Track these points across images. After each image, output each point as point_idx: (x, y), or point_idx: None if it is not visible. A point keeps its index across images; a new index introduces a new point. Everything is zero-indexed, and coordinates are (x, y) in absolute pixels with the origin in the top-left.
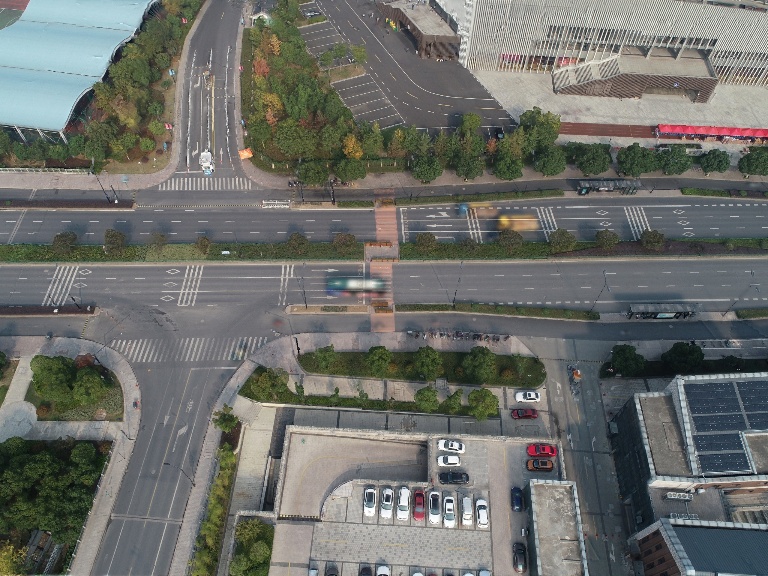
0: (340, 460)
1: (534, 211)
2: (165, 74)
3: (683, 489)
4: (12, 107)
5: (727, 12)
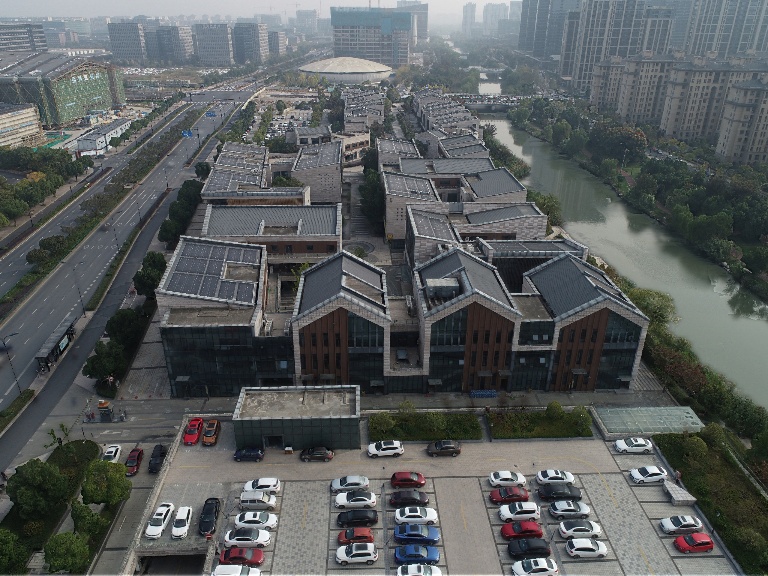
0: None
1: None
2: None
3: (261, 327)
4: None
5: None
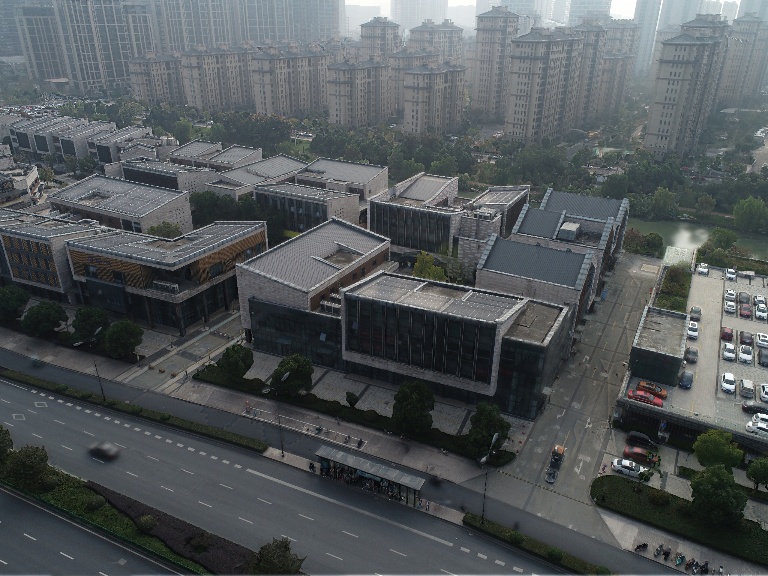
0: None
1: None
2: None
3: None
4: None
5: None
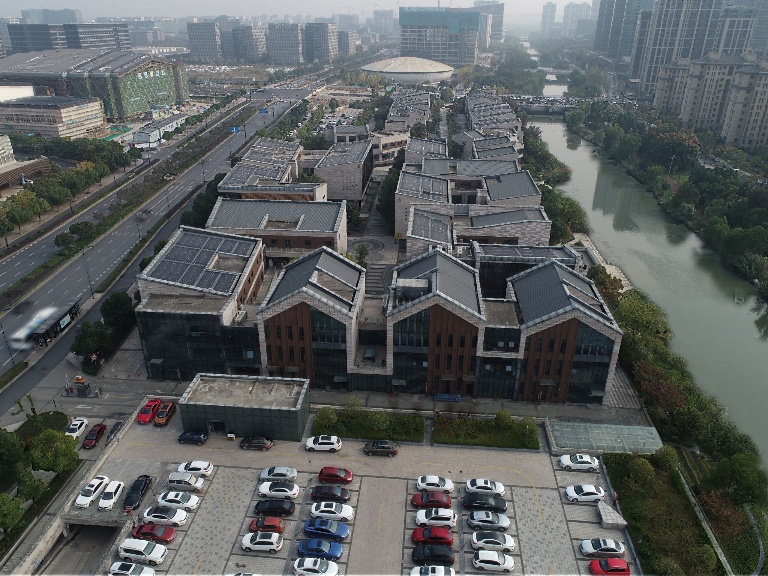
0: None
1: None
2: None
3: None
4: None
5: None
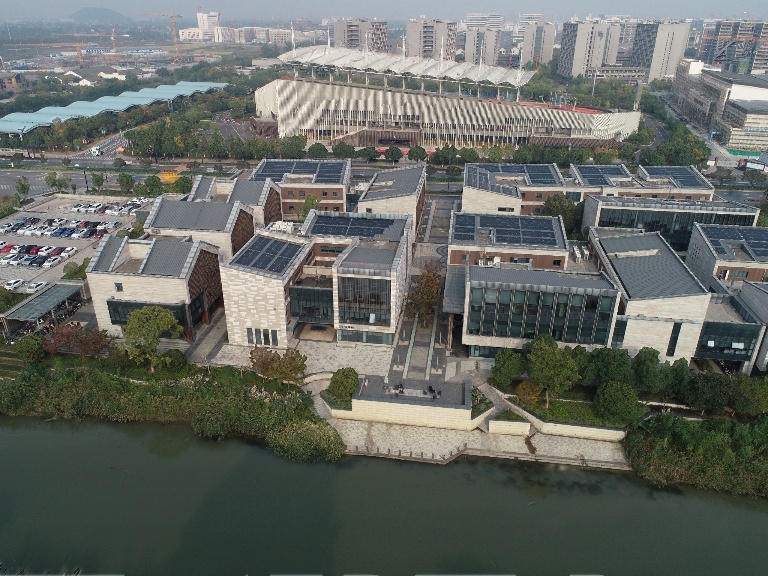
0: None
1: None
2: (102, 137)
3: None
4: (1, 127)
5: (417, 98)
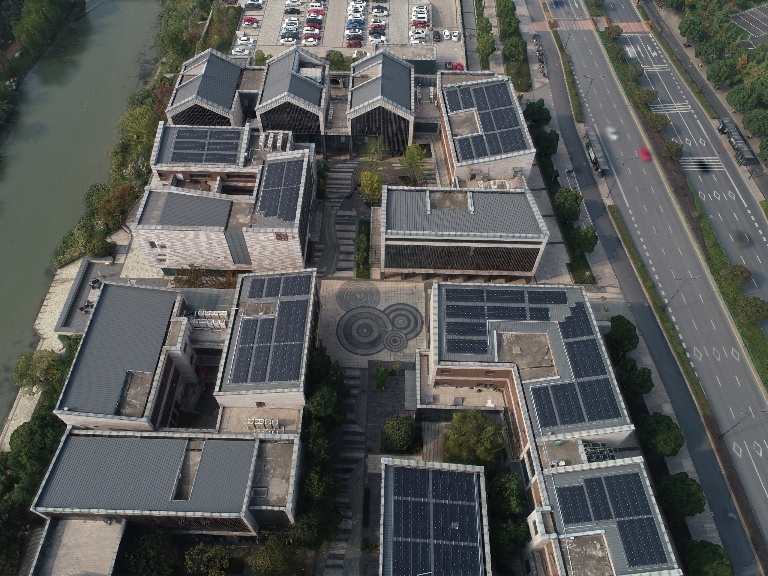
0: (442, 4)
1: (683, 101)
2: None
3: None
4: None
5: None
